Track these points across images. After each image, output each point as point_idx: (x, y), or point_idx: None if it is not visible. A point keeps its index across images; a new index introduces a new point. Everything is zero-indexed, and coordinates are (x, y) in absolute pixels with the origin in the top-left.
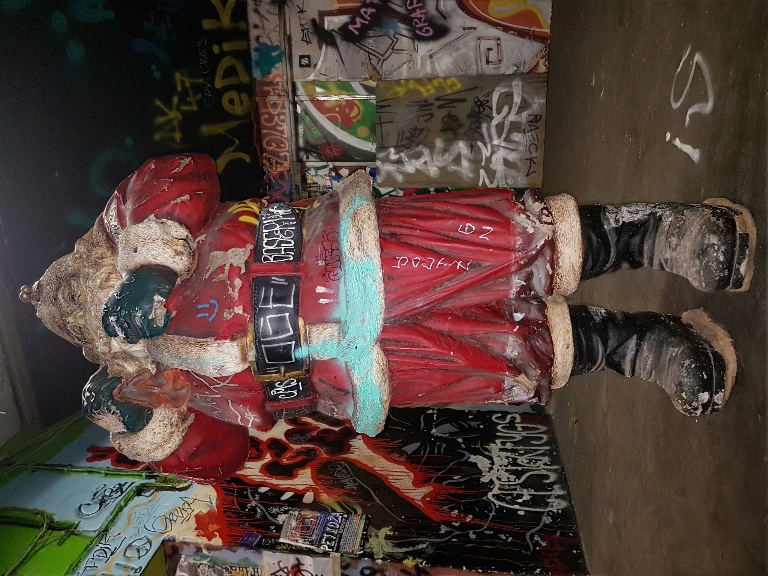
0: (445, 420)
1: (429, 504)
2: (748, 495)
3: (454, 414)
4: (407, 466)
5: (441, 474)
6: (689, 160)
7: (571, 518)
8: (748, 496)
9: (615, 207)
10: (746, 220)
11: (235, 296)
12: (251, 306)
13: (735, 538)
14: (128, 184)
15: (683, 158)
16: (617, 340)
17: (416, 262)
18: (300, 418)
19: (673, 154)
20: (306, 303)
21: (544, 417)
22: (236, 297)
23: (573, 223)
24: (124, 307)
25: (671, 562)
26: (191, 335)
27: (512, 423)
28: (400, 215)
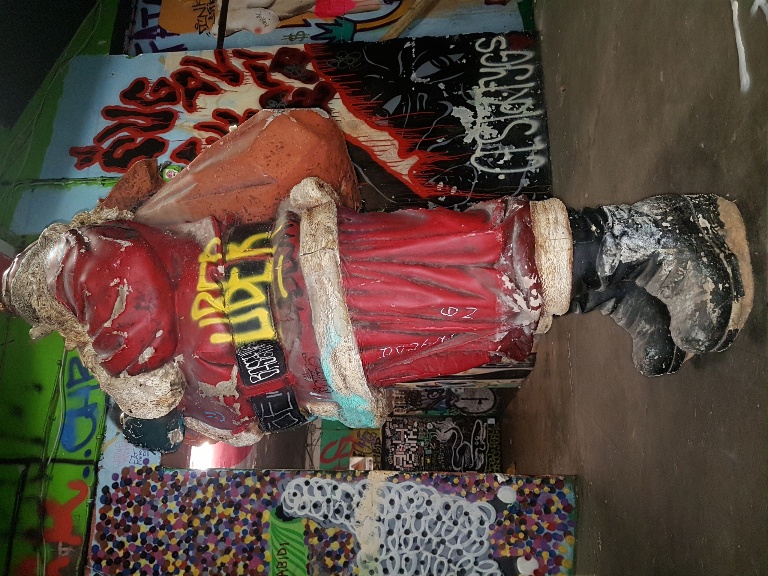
0: (425, 56)
1: (416, 179)
2: (672, 427)
3: (434, 45)
4: (391, 132)
5: (425, 138)
6: (737, 66)
7: (547, 178)
8: (672, 428)
9: (615, 244)
10: (744, 304)
11: (237, 413)
12: (254, 411)
13: (657, 424)
14: (63, 284)
15: (733, 46)
16: (595, 303)
17: (400, 350)
18: (270, 75)
19: (726, 13)
20: (303, 397)
21: (532, 37)
22: (239, 414)
23: (563, 290)
24: (145, 446)
25: (615, 345)
26: (207, 424)
27: (497, 51)
28: (377, 298)
